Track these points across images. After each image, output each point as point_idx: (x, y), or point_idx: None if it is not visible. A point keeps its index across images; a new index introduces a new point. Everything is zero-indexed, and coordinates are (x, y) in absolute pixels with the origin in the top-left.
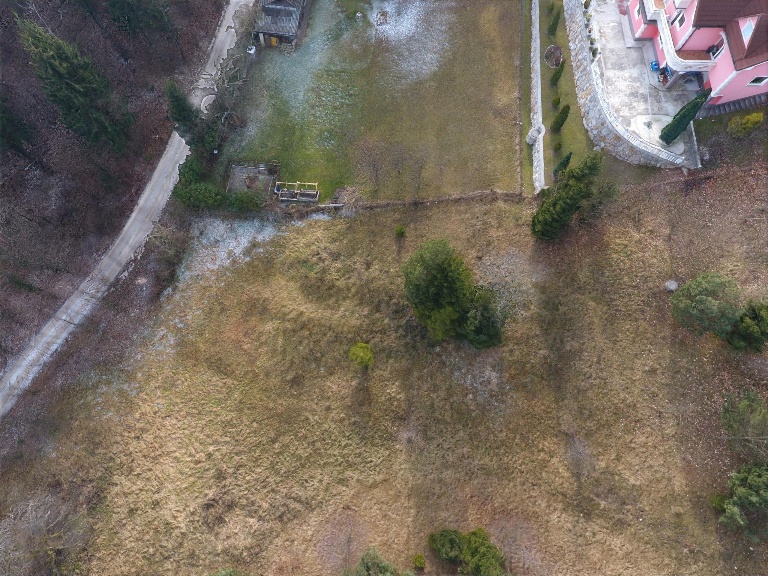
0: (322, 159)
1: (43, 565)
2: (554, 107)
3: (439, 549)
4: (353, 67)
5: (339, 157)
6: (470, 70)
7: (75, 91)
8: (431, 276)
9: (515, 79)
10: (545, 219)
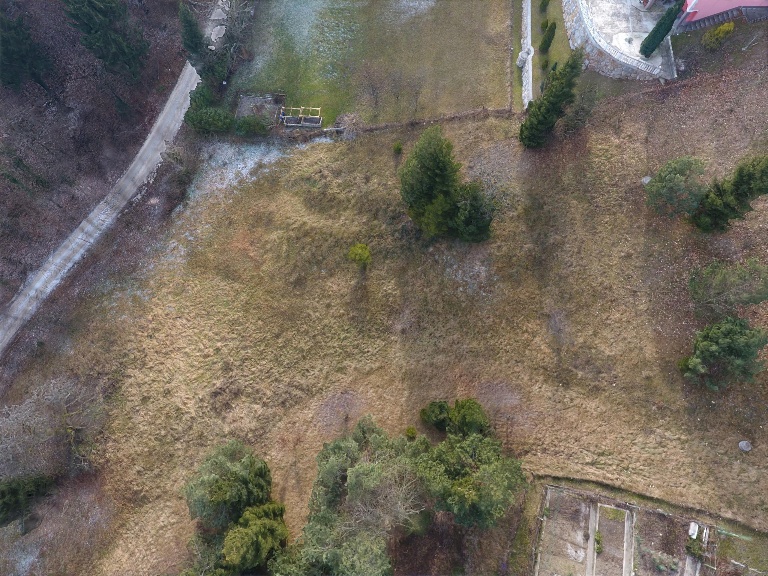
0: (325, 89)
1: (62, 447)
2: (543, 31)
3: (429, 416)
4: (355, 5)
5: (341, 87)
6: (465, 3)
7: (96, 10)
8: (425, 168)
9: (507, 10)
10: (531, 123)
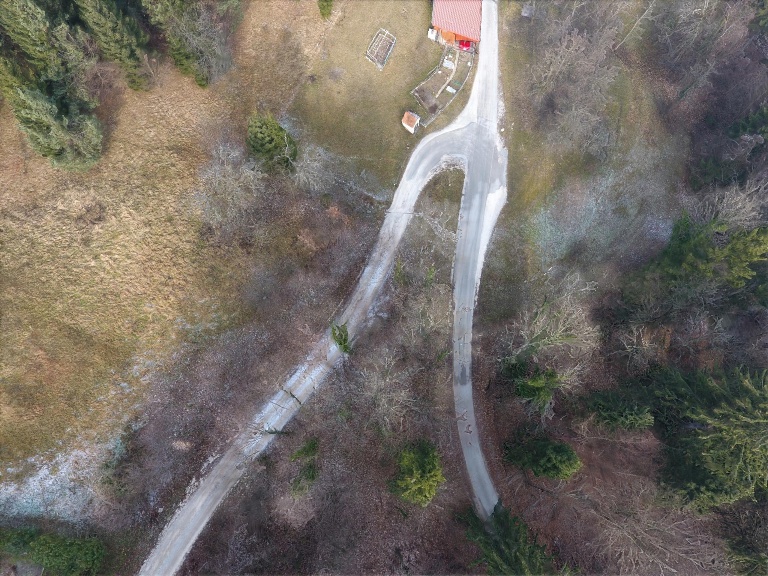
0: None
1: None
2: None
3: None
4: None
5: None
6: None
7: None
8: None
9: None
10: None
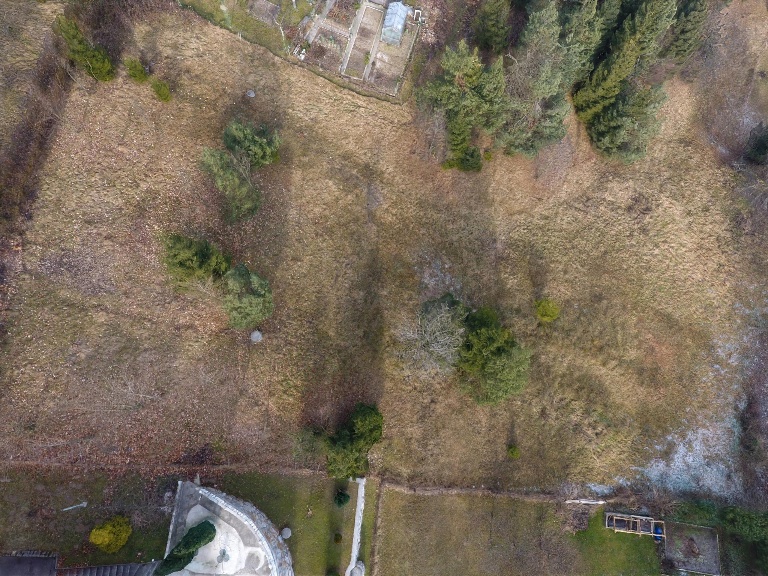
0: None
1: None
2: None
3: None
4: None
5: None
6: None
7: None
8: None
9: None
10: None
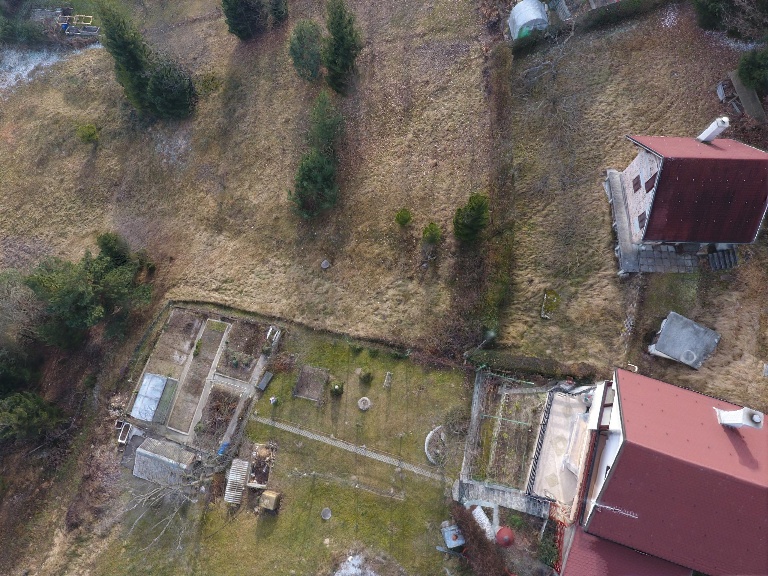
0: None
1: None
2: None
3: None
4: None
5: (123, 2)
6: None
7: None
8: (112, 42)
9: None
10: None
